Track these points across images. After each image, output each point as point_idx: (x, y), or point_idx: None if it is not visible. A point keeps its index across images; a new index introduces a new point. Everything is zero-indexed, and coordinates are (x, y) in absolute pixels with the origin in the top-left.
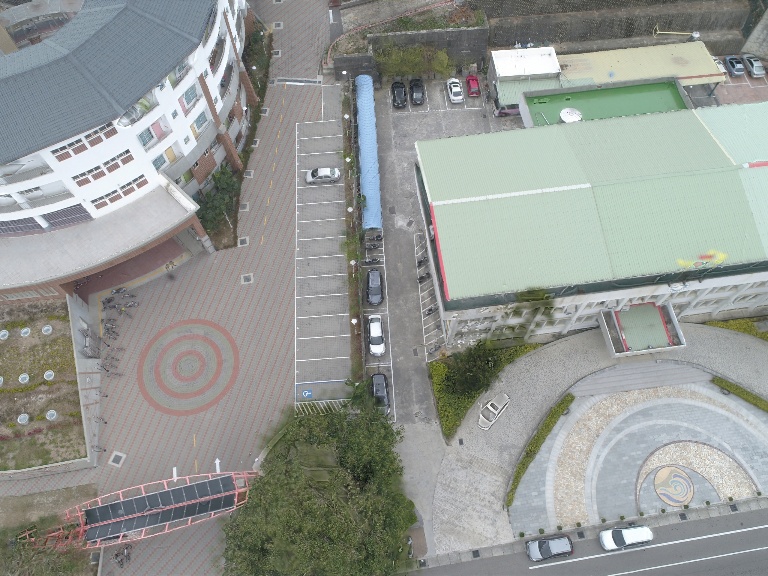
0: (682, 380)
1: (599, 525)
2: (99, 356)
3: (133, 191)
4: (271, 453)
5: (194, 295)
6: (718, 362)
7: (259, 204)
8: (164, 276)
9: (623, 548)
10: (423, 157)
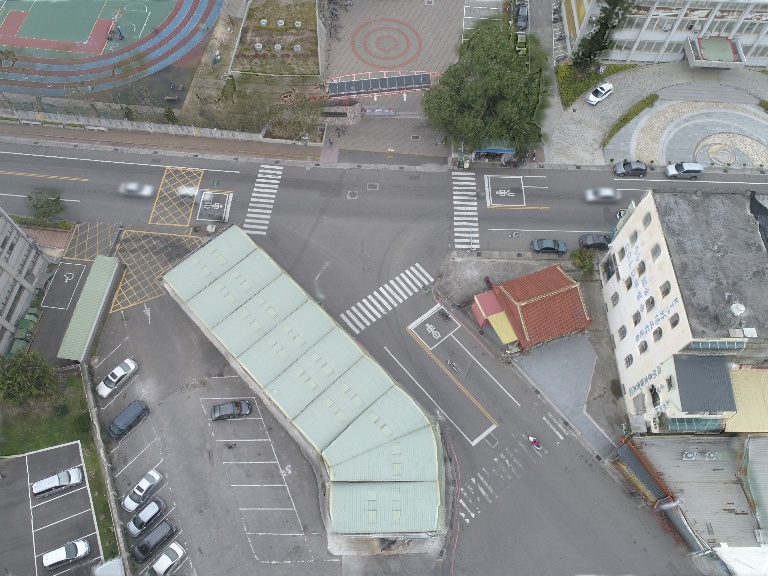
0: (738, 100)
1: (666, 166)
2: None
3: None
4: None
5: (392, 6)
6: (766, 94)
7: None
8: None
9: (682, 173)
10: None
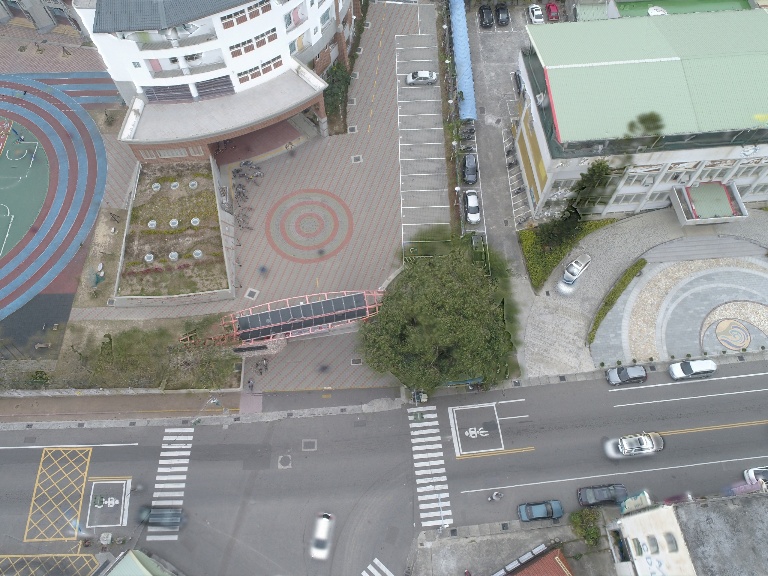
0: (741, 253)
1: (668, 361)
2: (233, 213)
3: (270, 70)
4: (391, 285)
5: (311, 170)
6: None
7: (365, 100)
8: (284, 154)
9: (690, 376)
10: (534, 36)
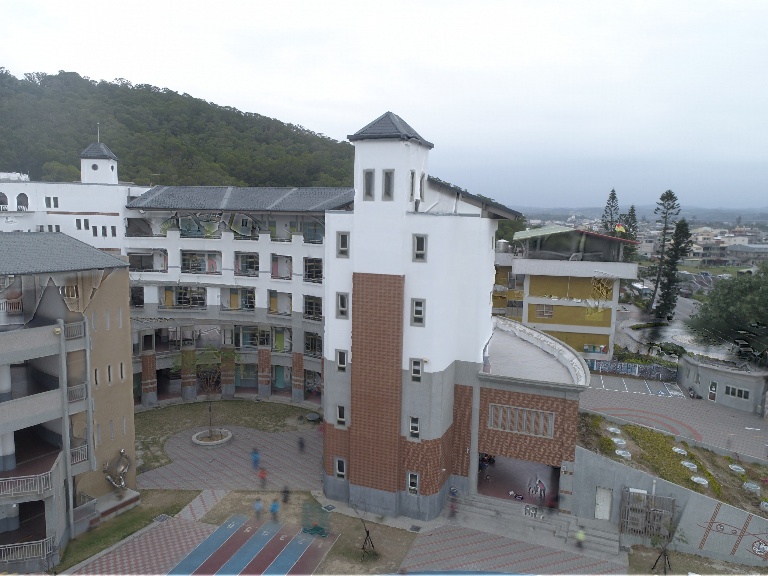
0: None
1: (736, 355)
2: None
3: None
4: None
5: None
6: None
7: None
8: None
9: None
10: None
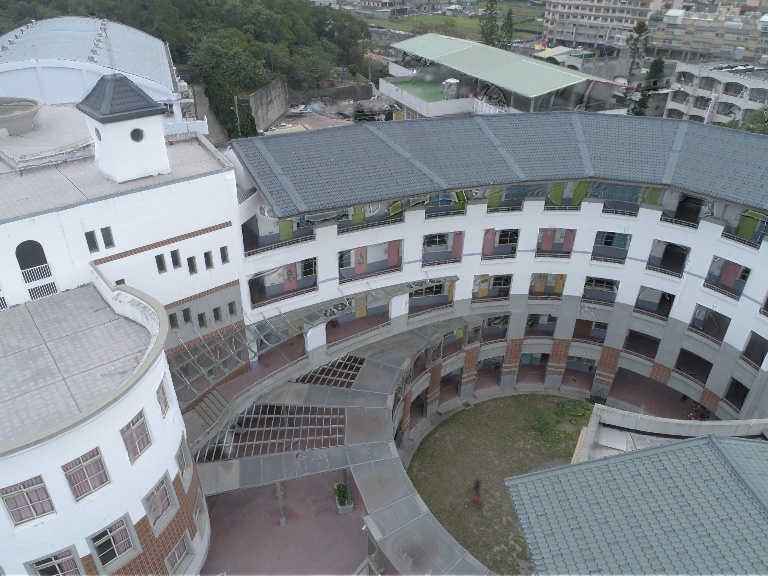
0: None
1: None
2: None
3: None
4: None
5: None
6: None
7: None
8: None
9: None
10: (544, 91)
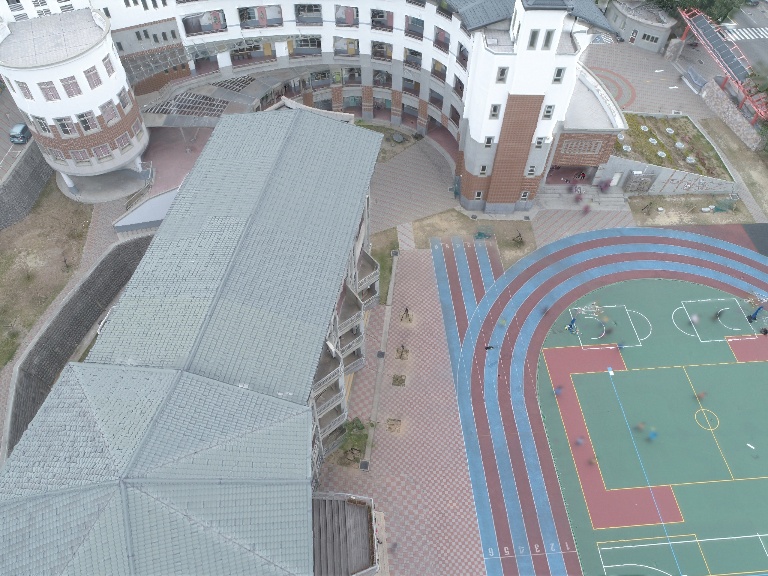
0: None
1: None
2: None
3: None
4: None
5: None
6: None
7: None
8: None
9: None
10: None
